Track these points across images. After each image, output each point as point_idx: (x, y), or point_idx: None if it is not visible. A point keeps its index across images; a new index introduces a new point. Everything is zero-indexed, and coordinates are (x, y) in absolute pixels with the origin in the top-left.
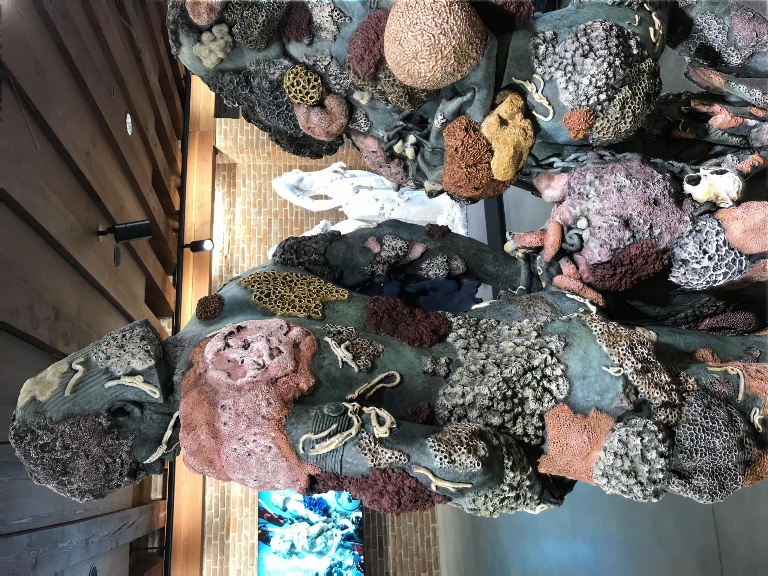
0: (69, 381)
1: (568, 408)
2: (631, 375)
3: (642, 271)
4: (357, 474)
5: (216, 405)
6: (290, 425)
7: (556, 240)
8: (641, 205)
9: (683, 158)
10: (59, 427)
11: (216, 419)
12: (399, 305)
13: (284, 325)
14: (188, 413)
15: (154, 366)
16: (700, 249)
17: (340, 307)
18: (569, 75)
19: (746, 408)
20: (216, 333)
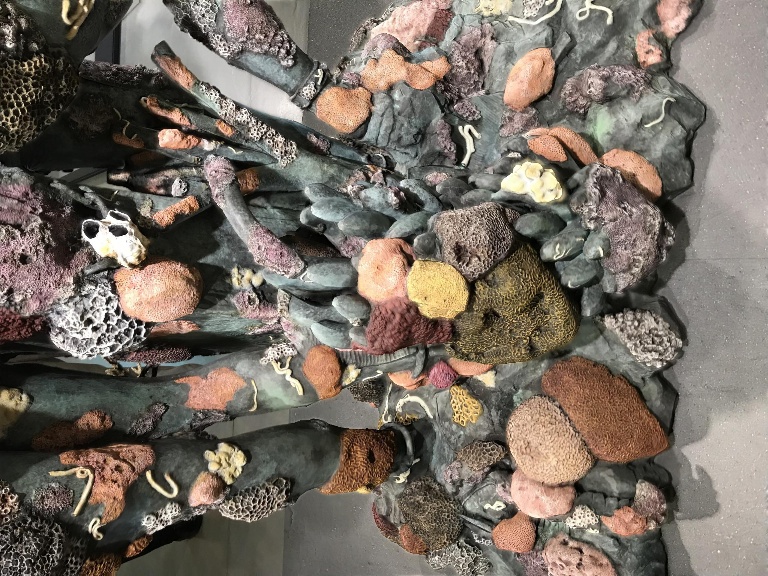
0: None
1: None
2: None
3: (5, 336)
4: None
5: None
6: None
7: None
8: None
9: (134, 163)
10: None
11: None
12: None
13: None
14: None
15: None
16: (81, 319)
17: None
18: None
19: (84, 520)
20: None
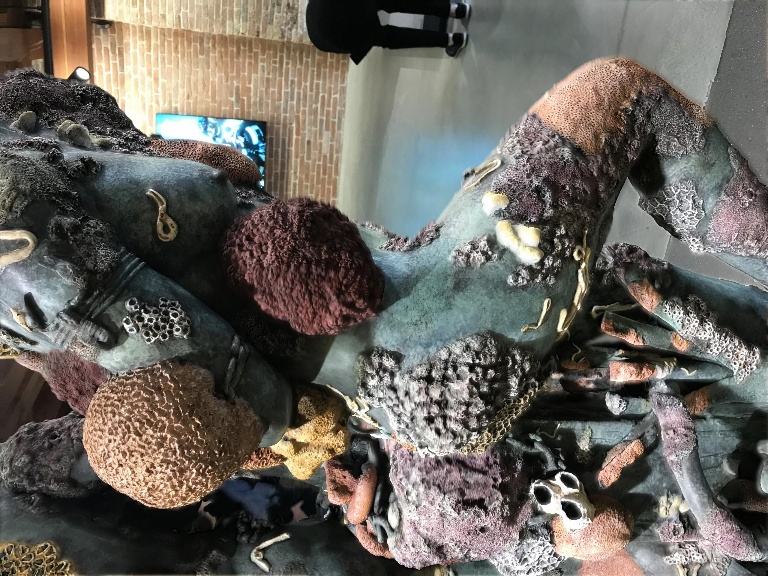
0: None
1: None
2: None
3: None
4: None
5: None
6: None
7: (360, 518)
8: (463, 536)
9: None
10: None
11: None
12: None
13: None
14: None
15: None
16: (520, 561)
17: None
18: (403, 427)
19: None
20: None
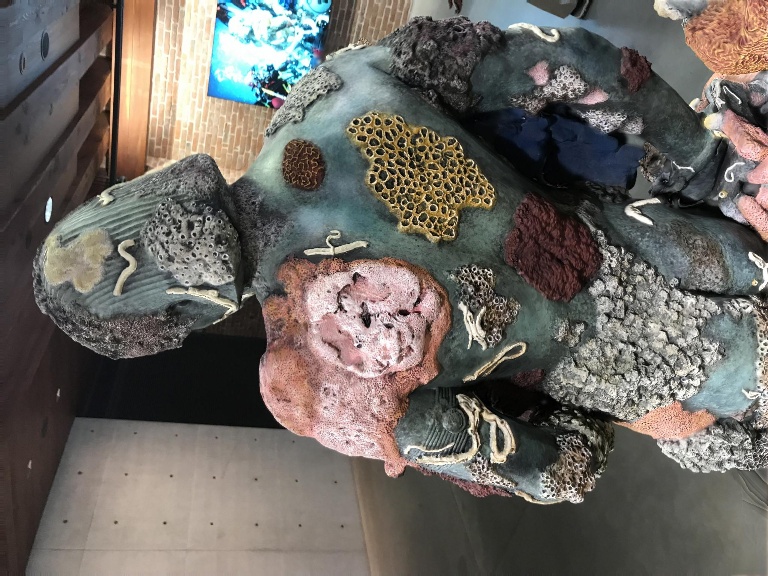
0: (118, 277)
1: (680, 406)
2: (764, 400)
3: None
4: (455, 476)
5: (318, 387)
6: (401, 430)
7: None
8: None
9: None
10: (108, 325)
11: (316, 402)
12: (550, 223)
13: (416, 290)
14: (281, 381)
15: (233, 282)
16: None
17: (479, 219)
18: None
19: None
20: (319, 254)
